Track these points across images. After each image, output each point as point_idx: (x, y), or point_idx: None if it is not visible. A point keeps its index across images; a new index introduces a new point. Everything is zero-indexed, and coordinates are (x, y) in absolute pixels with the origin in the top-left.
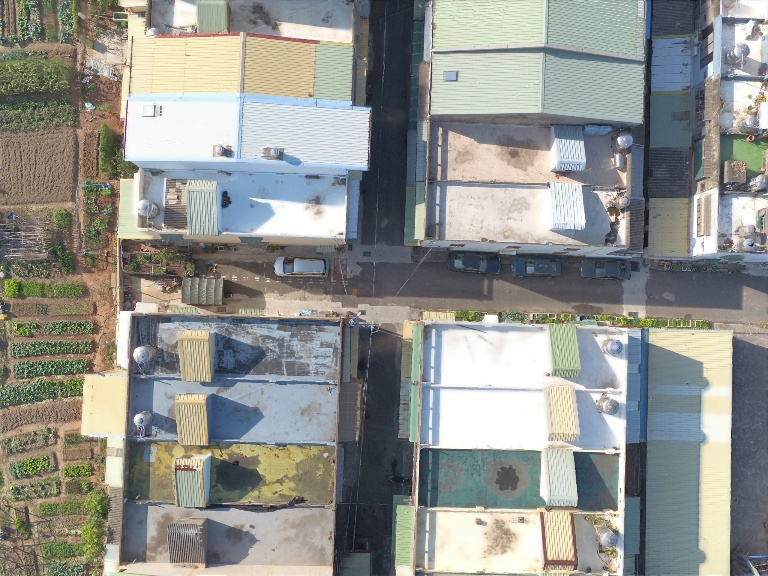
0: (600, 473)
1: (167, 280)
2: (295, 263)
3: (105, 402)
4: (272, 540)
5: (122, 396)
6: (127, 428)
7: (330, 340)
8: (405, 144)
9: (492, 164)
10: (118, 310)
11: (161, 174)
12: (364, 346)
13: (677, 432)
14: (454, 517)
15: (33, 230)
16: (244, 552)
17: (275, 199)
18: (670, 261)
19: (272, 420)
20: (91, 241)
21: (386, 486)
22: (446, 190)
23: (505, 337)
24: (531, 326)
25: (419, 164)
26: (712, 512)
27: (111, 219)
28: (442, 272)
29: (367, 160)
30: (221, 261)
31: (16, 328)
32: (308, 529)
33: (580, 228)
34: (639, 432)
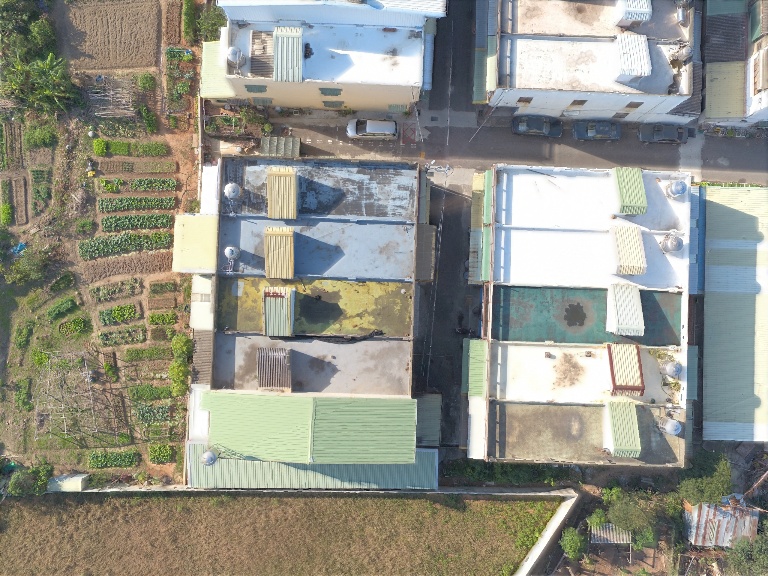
0: (663, 311)
1: (245, 142)
2: (368, 124)
3: (195, 241)
4: (352, 370)
5: (211, 234)
6: (217, 262)
7: (407, 183)
8: (471, 15)
9: (560, 19)
10: (200, 168)
11: (247, 27)
12: (432, 206)
13: (733, 284)
14: (524, 351)
15: (120, 93)
16: (326, 381)
17: (355, 51)
18: (725, 127)
19: (352, 258)
20: (174, 103)
21: (453, 338)
22: (517, 43)
23: (573, 182)
24: (598, 169)
25: (491, 19)
26: (767, 360)
27: (192, 83)
28: (506, 136)
29: (445, 7)
30: (296, 125)
31: (104, 184)
32: (386, 360)
33: (646, 74)
34: (697, 284)
